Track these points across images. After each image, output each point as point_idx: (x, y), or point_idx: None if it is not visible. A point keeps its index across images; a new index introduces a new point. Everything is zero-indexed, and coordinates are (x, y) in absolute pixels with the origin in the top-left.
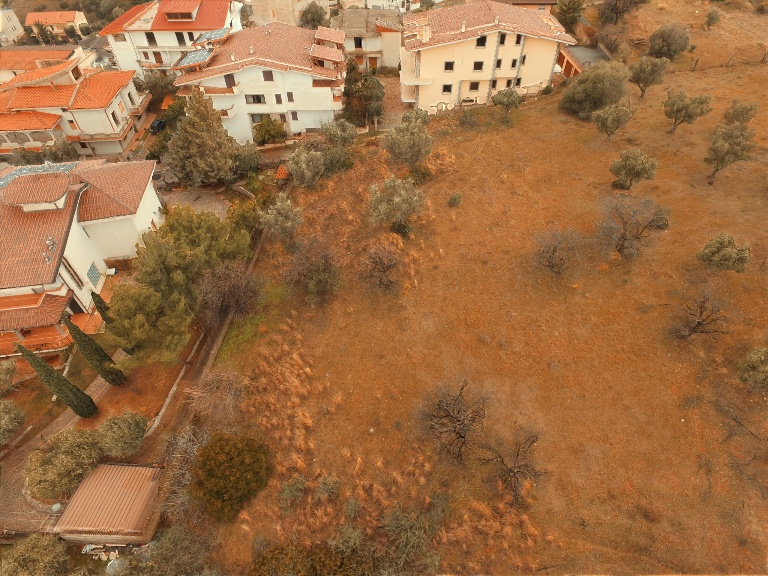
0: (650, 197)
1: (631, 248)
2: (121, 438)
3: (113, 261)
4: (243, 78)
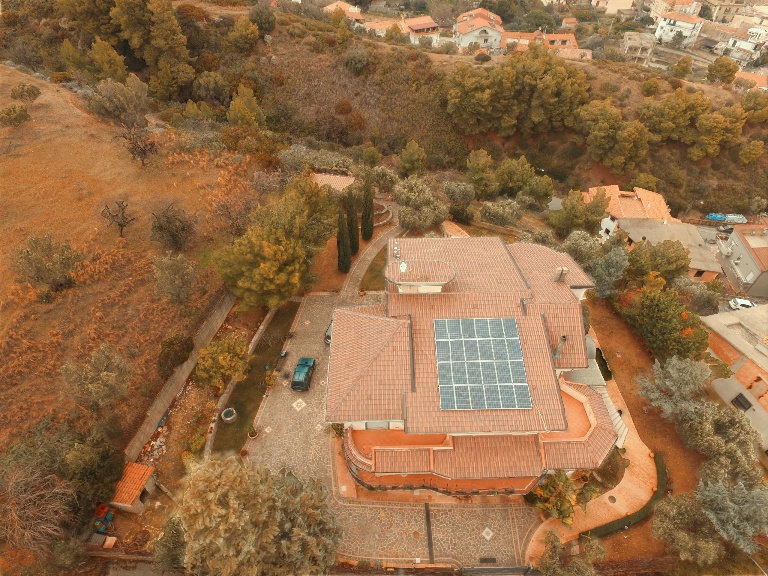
0: None
1: None
2: None
3: None
4: None
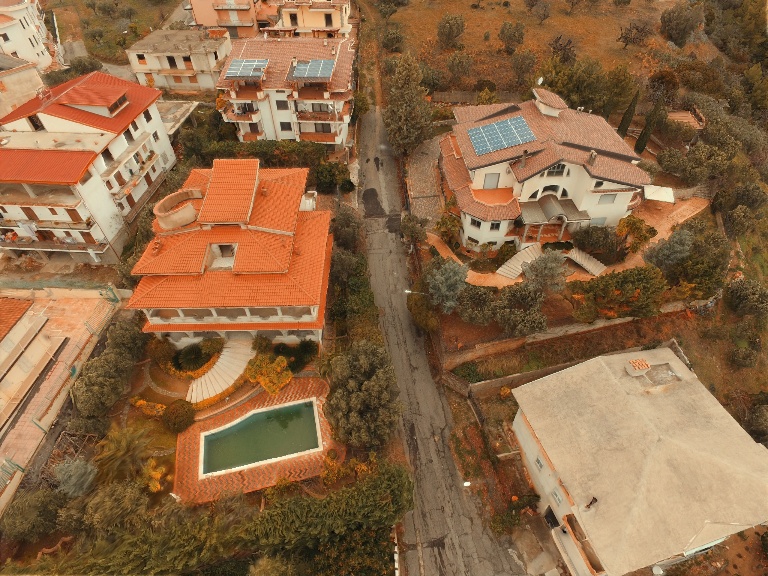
0: (484, 4)
1: (537, 2)
2: None
3: None
4: None
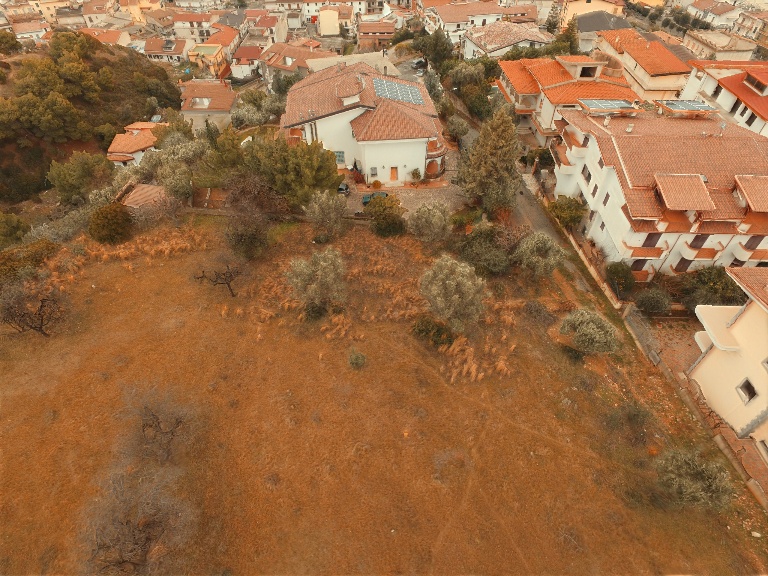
0: None
1: None
2: (166, 185)
3: None
4: None
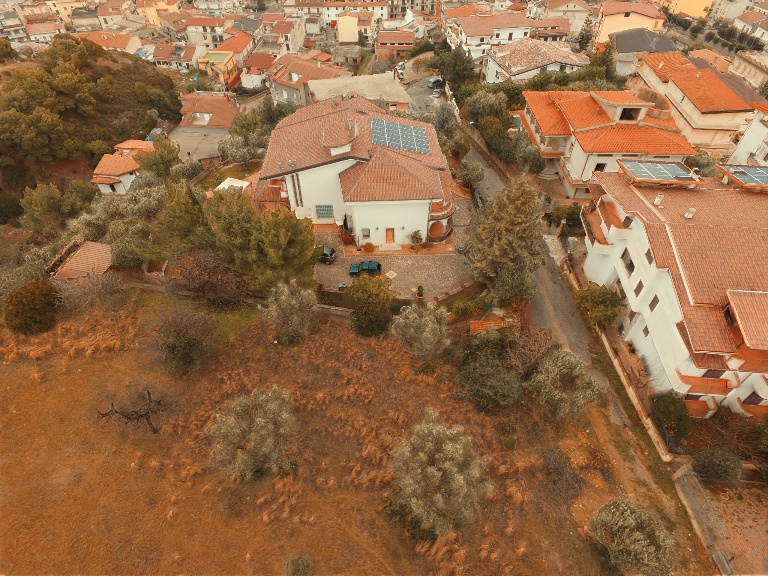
0: None
1: None
2: (112, 249)
3: (345, 219)
4: (636, 229)
